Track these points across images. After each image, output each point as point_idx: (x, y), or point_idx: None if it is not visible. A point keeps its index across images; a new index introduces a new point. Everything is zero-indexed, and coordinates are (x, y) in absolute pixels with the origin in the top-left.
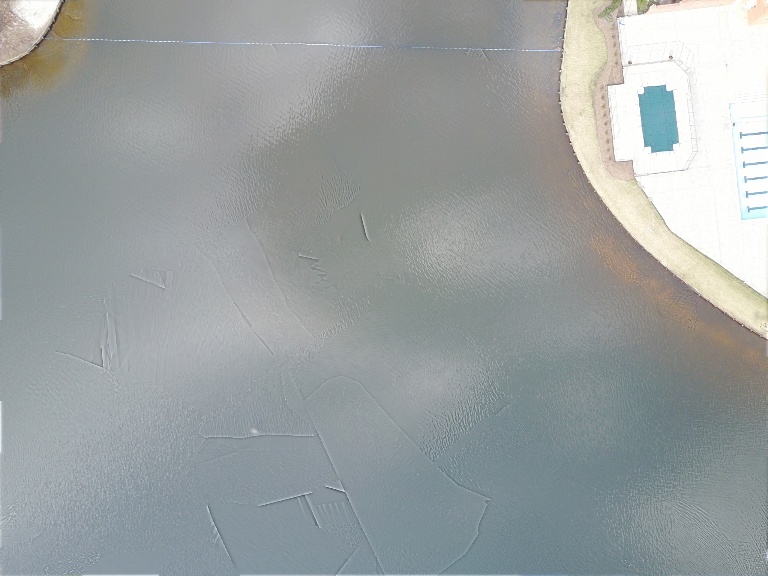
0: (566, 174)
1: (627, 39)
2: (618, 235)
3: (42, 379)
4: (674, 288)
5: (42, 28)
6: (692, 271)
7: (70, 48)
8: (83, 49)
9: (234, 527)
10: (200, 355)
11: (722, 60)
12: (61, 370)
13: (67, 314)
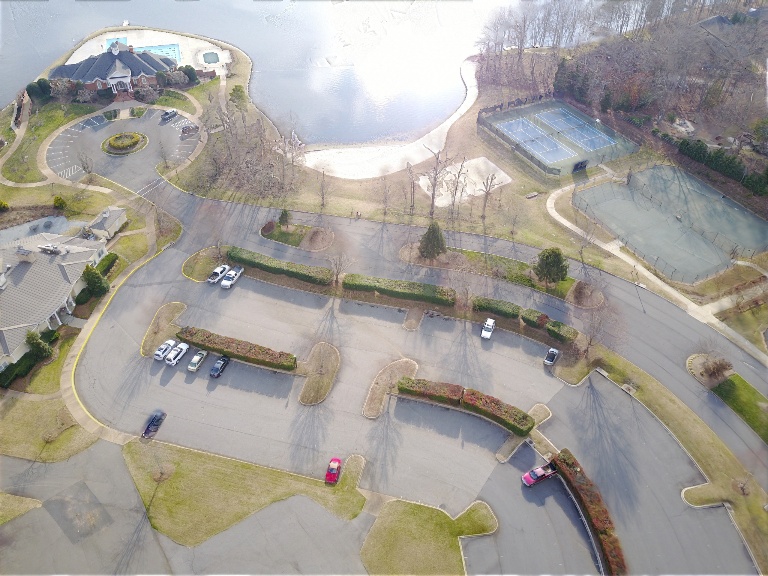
0: None
1: None
2: None
3: None
4: None
5: None
6: None
7: None
8: None
9: None
10: None
11: None
12: None
13: None
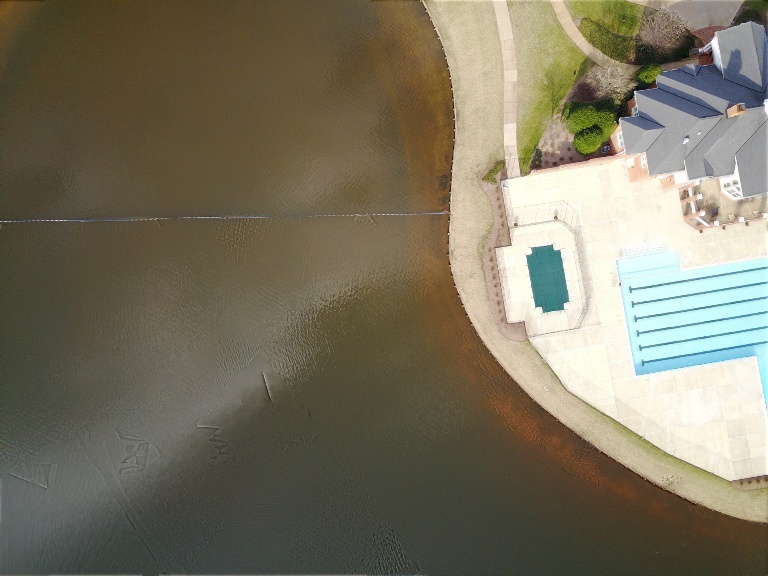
0: (460, 336)
1: (512, 201)
2: (516, 395)
3: None
4: (575, 445)
5: None
6: (591, 428)
7: None
8: None
9: None
10: (82, 563)
11: (606, 217)
12: None
13: None
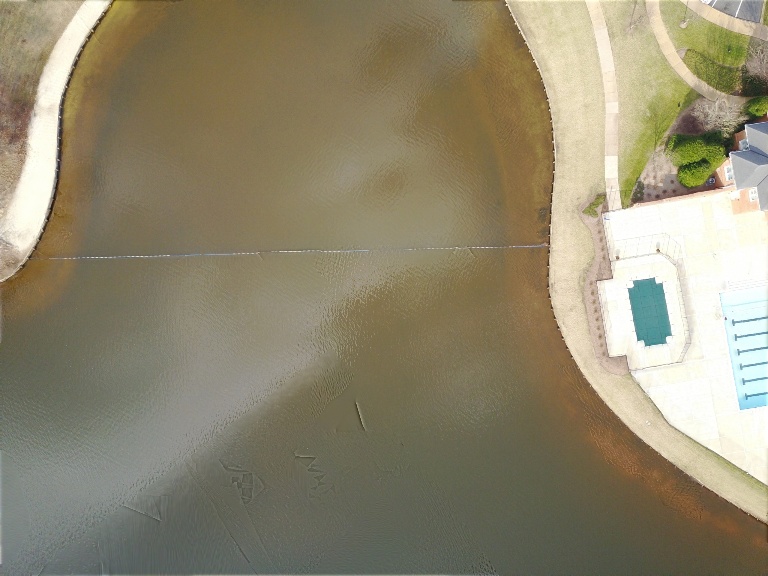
0: (560, 369)
1: (613, 234)
2: (616, 428)
3: None
4: (676, 479)
5: (27, 249)
6: (694, 463)
7: (56, 245)
8: (69, 243)
9: None
10: None
11: (709, 250)
12: None
13: (61, 571)
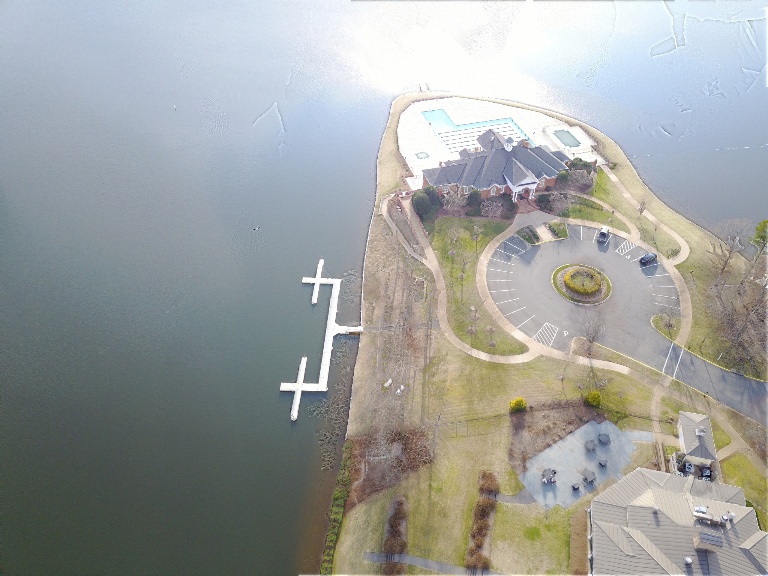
0: None
1: None
2: None
3: (764, 80)
4: None
5: None
6: None
7: None
8: None
9: (674, 4)
10: None
11: None
12: (759, 86)
13: None
